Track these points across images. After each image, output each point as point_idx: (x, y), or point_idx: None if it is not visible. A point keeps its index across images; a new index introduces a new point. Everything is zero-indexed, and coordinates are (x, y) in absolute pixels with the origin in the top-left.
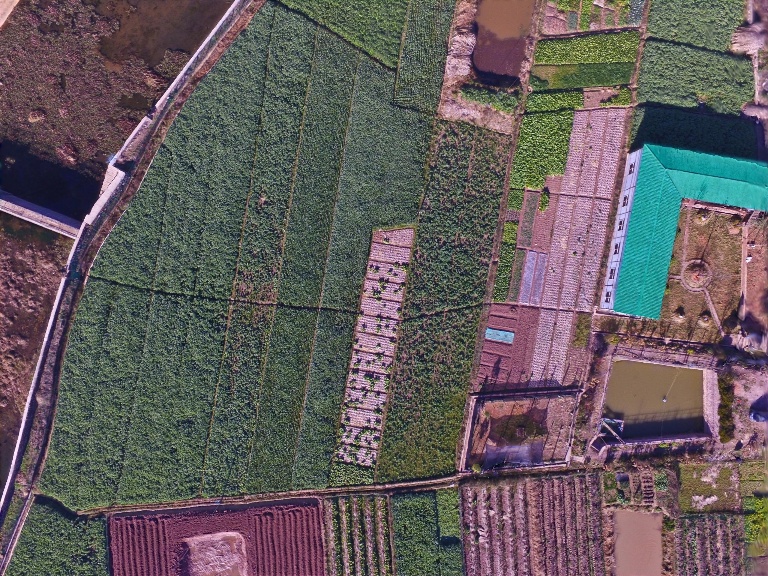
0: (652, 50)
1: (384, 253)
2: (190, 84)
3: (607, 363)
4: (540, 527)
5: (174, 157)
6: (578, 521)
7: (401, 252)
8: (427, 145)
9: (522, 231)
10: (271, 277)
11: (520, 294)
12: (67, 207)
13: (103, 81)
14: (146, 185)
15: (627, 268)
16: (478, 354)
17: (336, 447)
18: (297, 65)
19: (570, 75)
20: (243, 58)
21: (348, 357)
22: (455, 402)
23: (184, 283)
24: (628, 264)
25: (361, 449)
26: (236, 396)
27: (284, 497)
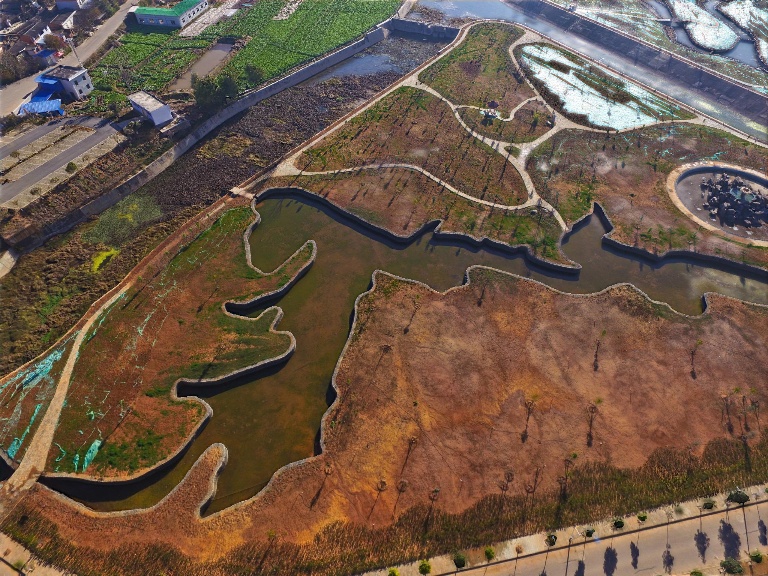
0: None
1: None
2: None
3: None
4: None
5: None
6: None
7: None
8: None
9: None
10: None
11: None
12: (403, 32)
13: None
14: None
15: (198, 0)
16: (256, 2)
17: None
18: None
19: None
20: None
21: None
22: None
23: None
24: None
25: None
26: None
27: None
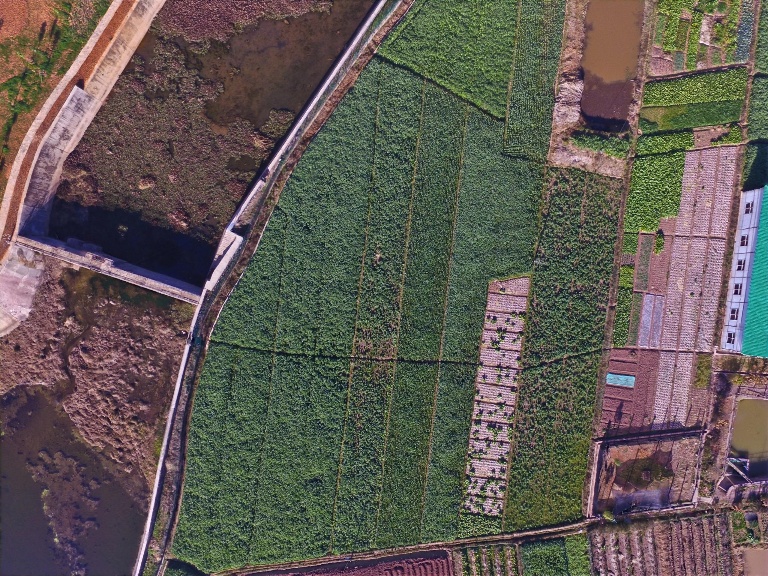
0: (762, 86)
1: (501, 303)
2: (300, 144)
3: (731, 403)
4: (671, 569)
5: (289, 219)
6: (708, 562)
7: (517, 301)
8: (539, 193)
9: (638, 274)
10: (390, 333)
11: (639, 338)
12: (181, 272)
13: (210, 144)
14: (263, 248)
15: (754, 310)
16: (600, 400)
17: (462, 499)
18: (406, 120)
19: (679, 116)
20: (353, 116)
21: (470, 409)
22: (579, 448)
23: (305, 343)
24: (754, 306)
25: (487, 499)
26: (362, 453)
27: (413, 551)
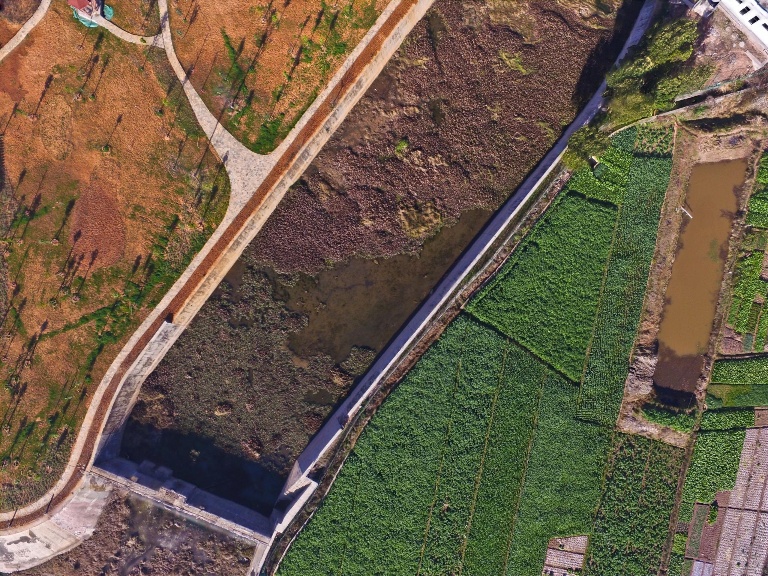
0: None
1: (559, 559)
2: (380, 391)
3: None
4: None
5: (364, 465)
6: None
7: (575, 558)
8: (606, 458)
9: (691, 542)
10: None
11: None
12: (249, 499)
13: (290, 376)
14: (335, 492)
15: None
16: None
17: None
18: (486, 378)
19: (743, 394)
20: (435, 371)
21: None
22: None
23: None
24: None
25: None
26: None
27: None
